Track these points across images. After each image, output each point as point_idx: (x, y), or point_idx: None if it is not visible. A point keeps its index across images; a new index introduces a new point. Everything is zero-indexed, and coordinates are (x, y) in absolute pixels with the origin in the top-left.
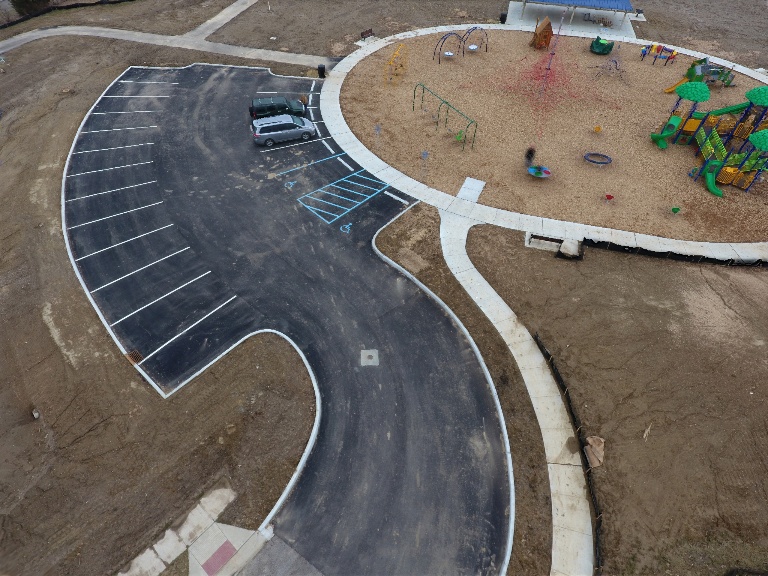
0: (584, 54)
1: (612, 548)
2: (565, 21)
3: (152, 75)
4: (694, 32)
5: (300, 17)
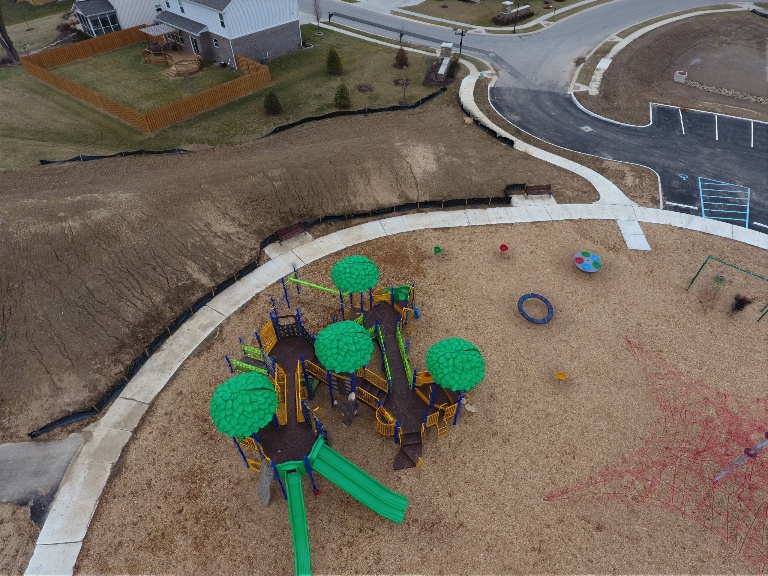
0: None
1: None
2: None
3: None
4: None
5: None
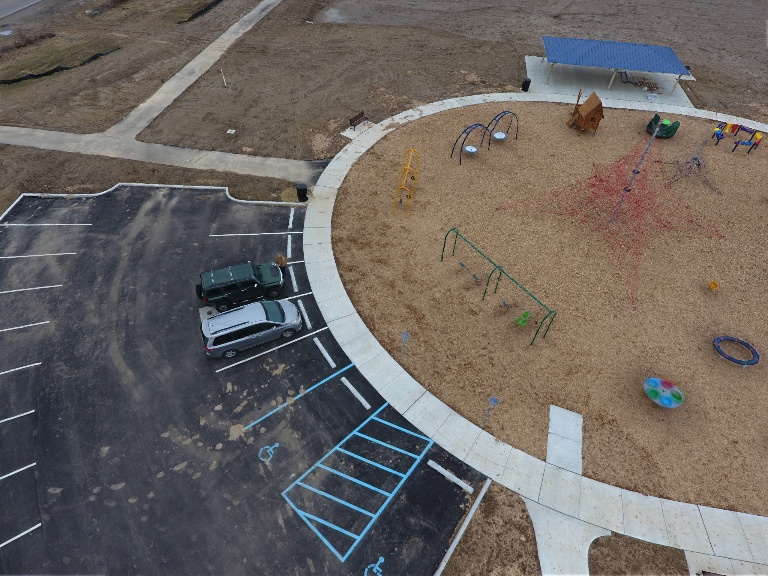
0: (641, 138)
1: None
2: (600, 84)
3: (53, 210)
4: (757, 94)
5: (266, 93)
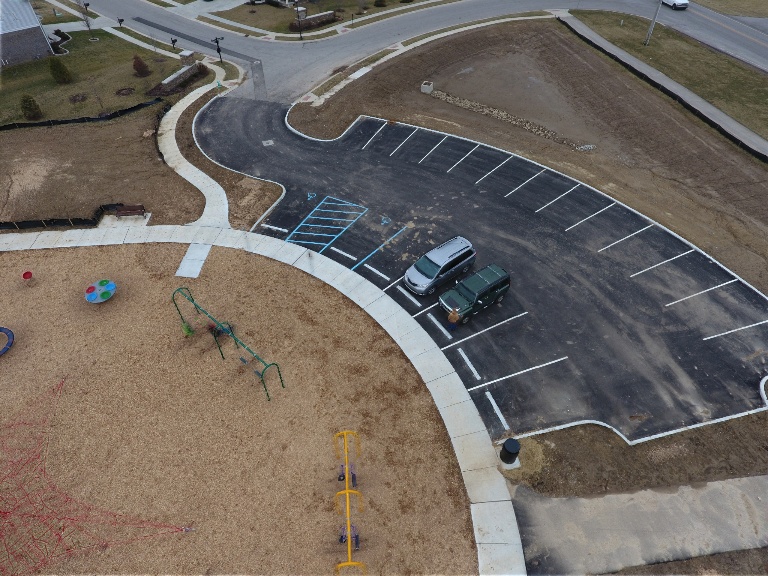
0: None
1: (156, 117)
2: None
3: None
4: None
5: None
